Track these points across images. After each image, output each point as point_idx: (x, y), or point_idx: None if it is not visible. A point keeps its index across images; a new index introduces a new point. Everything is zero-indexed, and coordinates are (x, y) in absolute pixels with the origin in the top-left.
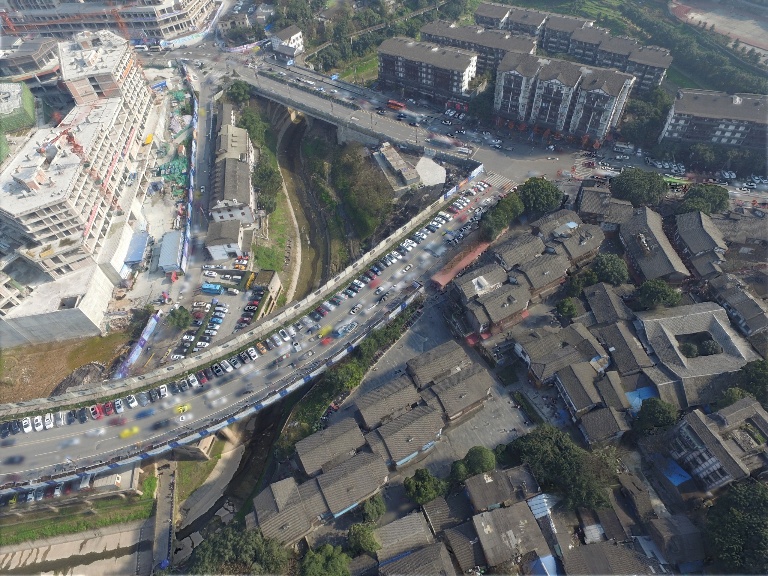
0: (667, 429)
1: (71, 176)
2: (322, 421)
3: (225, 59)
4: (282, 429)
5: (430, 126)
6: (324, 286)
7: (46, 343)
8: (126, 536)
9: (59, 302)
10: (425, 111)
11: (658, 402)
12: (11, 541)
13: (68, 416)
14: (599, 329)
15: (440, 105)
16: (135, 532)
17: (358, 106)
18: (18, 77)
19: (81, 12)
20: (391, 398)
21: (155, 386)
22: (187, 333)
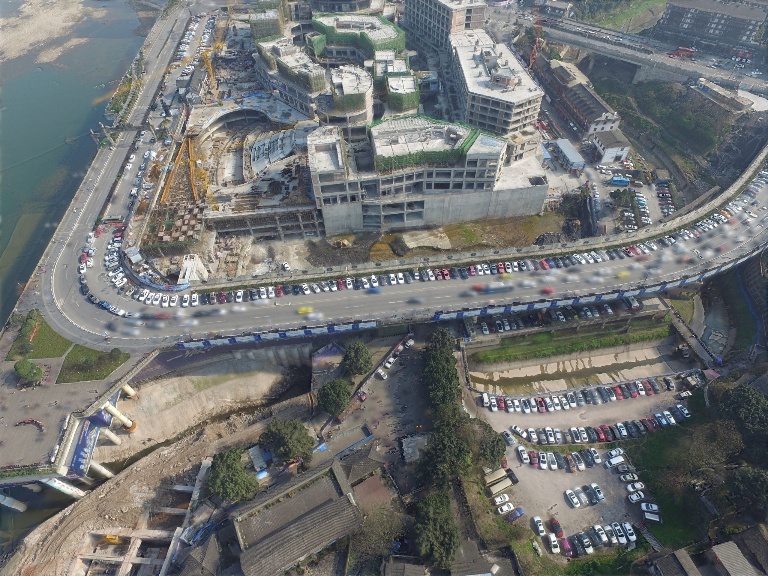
0: None
1: (529, 79)
2: None
3: (494, 12)
4: (761, 273)
5: (726, 68)
6: (744, 174)
7: (496, 219)
8: (648, 352)
9: (528, 180)
10: None
11: None
12: (567, 350)
13: (610, 253)
14: None
15: (721, 53)
16: (653, 349)
17: (652, 51)
18: None
19: None
20: None
21: (659, 237)
22: (625, 211)
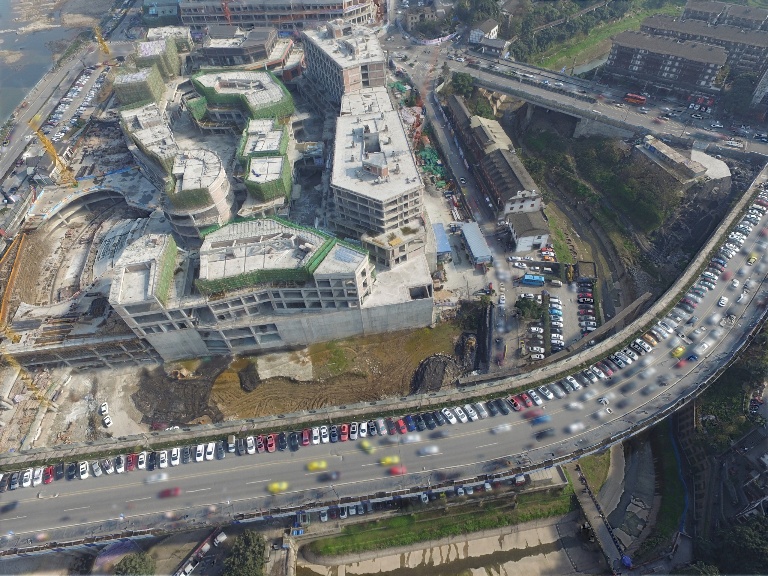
0: None
1: (412, 163)
2: (752, 415)
3: (424, 52)
4: (694, 423)
5: (681, 120)
6: (681, 278)
7: (376, 334)
8: (543, 532)
9: (409, 292)
10: (666, 105)
11: None
12: (435, 536)
13: (490, 407)
14: None
15: (678, 99)
16: (551, 528)
17: (596, 99)
18: (250, 66)
19: (266, 3)
20: None
21: (559, 378)
22: (532, 325)
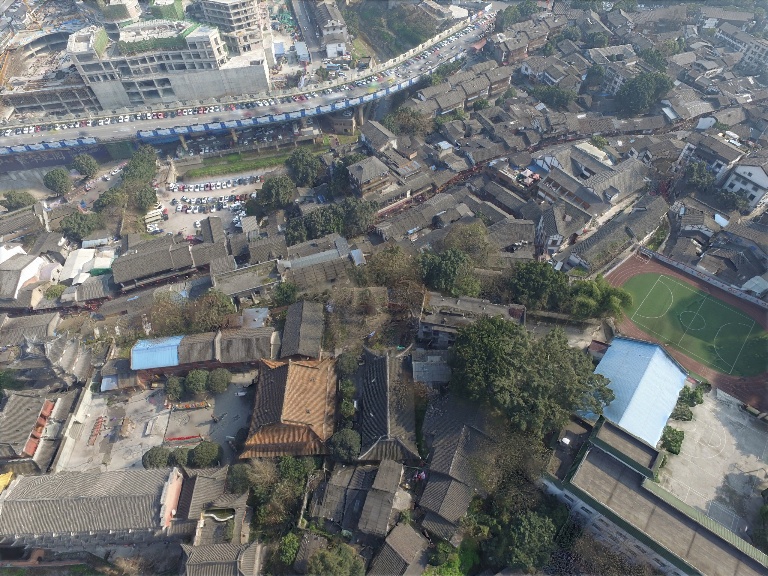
0: (600, 82)
1: None
2: None
3: None
4: None
5: None
6: (408, 52)
7: None
8: None
9: (249, 63)
10: None
11: (595, 65)
12: (253, 167)
13: (282, 99)
14: (566, 57)
15: None
16: None
17: None
18: None
19: None
20: (462, 75)
21: None
22: None
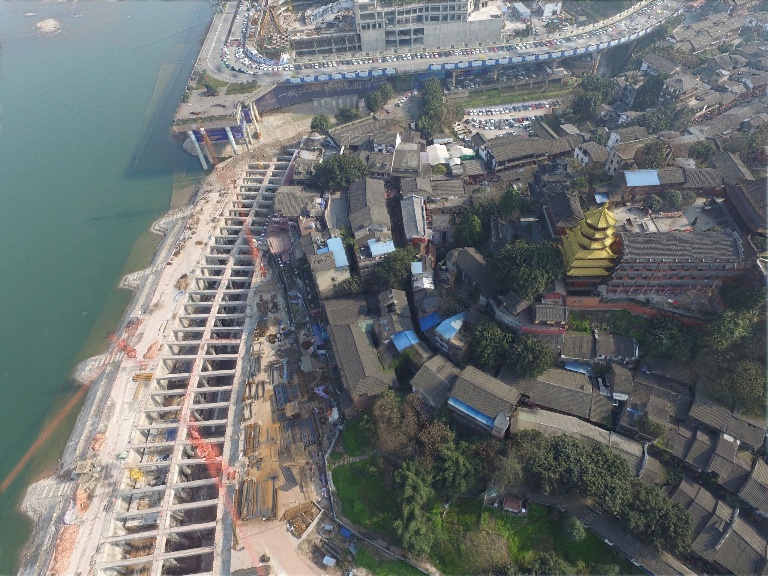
0: None
1: None
2: None
3: None
4: None
5: None
6: (630, 9)
7: None
8: None
9: (490, 16)
10: None
11: None
12: (510, 101)
13: (535, 44)
14: None
15: None
16: None
17: None
18: None
19: None
20: (702, 23)
21: None
22: None
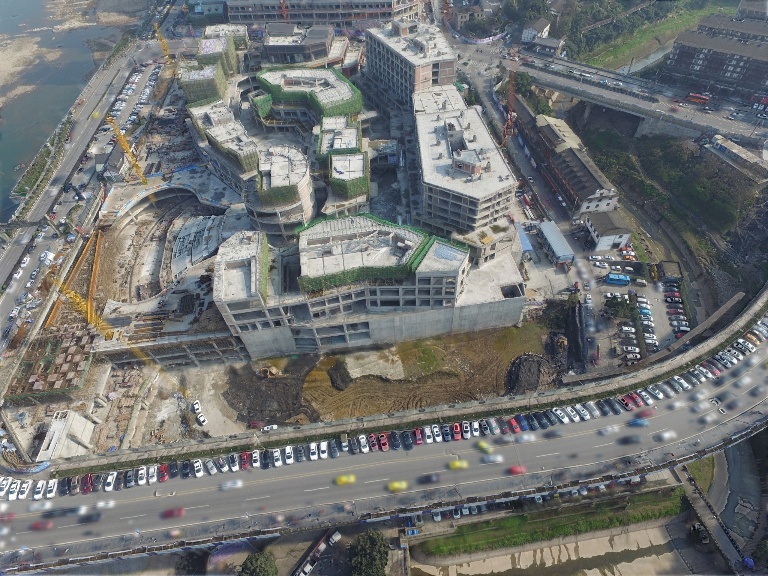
0: None
1: (501, 161)
2: None
3: (476, 51)
4: None
5: (747, 119)
6: None
7: (463, 333)
8: (653, 533)
9: (500, 290)
10: (730, 104)
11: None
12: (546, 537)
13: (601, 407)
14: None
15: (740, 99)
16: (661, 529)
17: (658, 99)
18: (311, 64)
19: (315, 2)
20: None
21: (666, 377)
22: (623, 324)
